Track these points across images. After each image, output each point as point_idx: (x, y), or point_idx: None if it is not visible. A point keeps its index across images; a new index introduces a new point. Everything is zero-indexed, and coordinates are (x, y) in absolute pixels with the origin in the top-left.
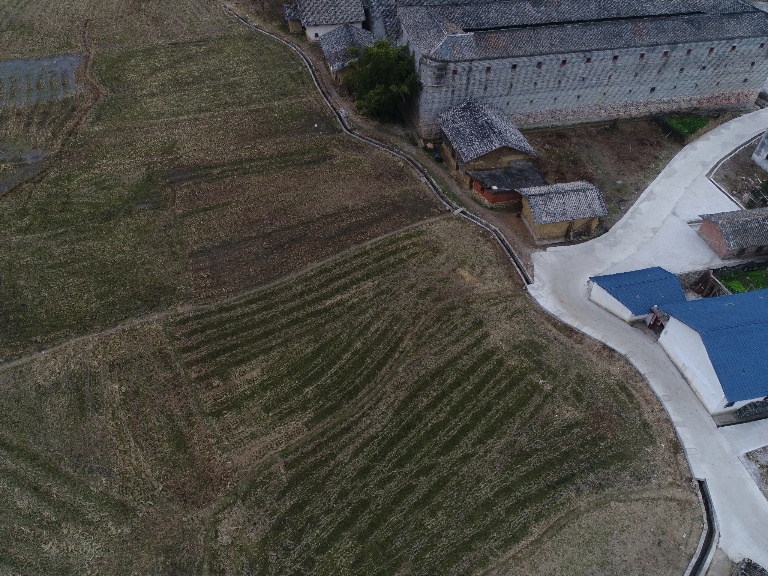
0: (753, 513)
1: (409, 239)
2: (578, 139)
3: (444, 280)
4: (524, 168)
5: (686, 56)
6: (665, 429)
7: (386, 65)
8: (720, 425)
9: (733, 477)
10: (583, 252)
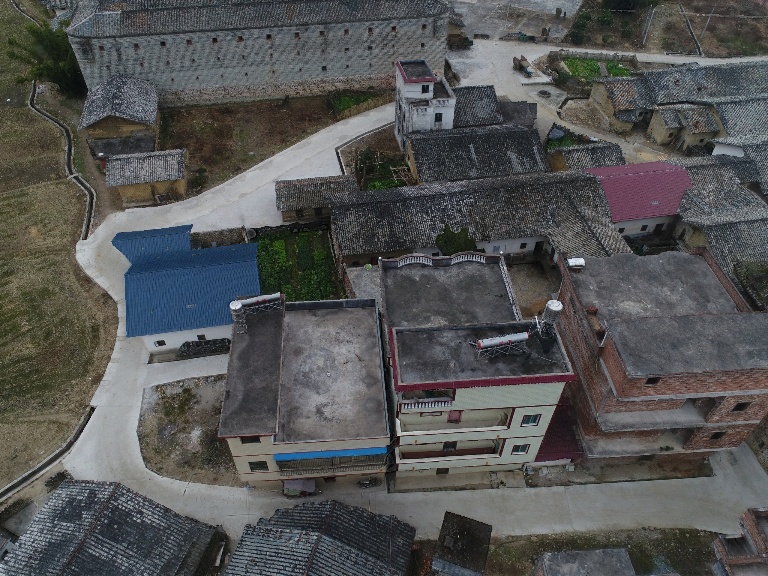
0: (115, 435)
1: (7, 200)
2: (244, 114)
3: (10, 236)
4: (144, 137)
5: (345, 36)
6: (103, 365)
7: (57, 42)
8: (156, 362)
9: (123, 405)
10: (157, 213)
